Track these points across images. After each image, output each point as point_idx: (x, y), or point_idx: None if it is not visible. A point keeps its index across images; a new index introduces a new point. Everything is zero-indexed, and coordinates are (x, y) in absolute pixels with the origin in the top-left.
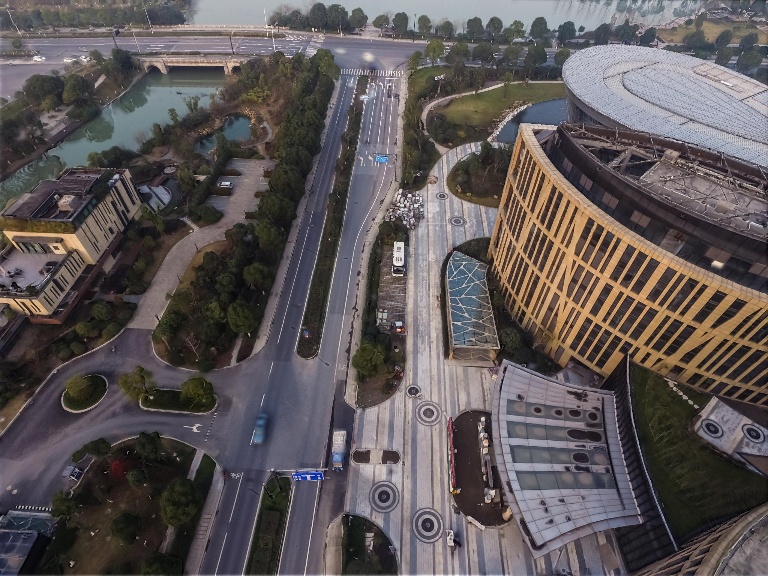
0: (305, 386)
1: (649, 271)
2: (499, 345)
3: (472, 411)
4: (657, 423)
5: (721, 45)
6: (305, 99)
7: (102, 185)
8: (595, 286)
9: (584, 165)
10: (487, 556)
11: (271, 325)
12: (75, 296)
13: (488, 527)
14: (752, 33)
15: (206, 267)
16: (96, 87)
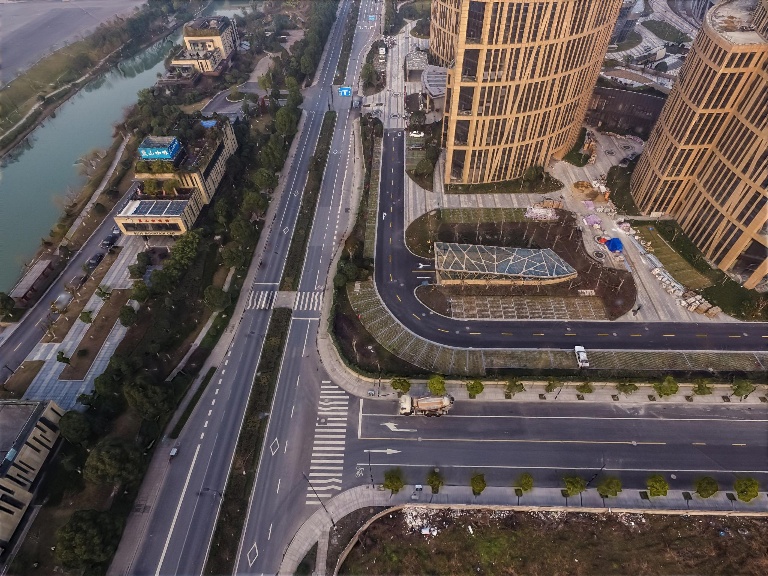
0: None
1: None
2: None
3: (416, 93)
4: None
5: None
6: None
7: (227, 19)
8: None
9: None
10: None
11: (319, 78)
12: (221, 67)
13: None
14: None
15: (283, 58)
16: None
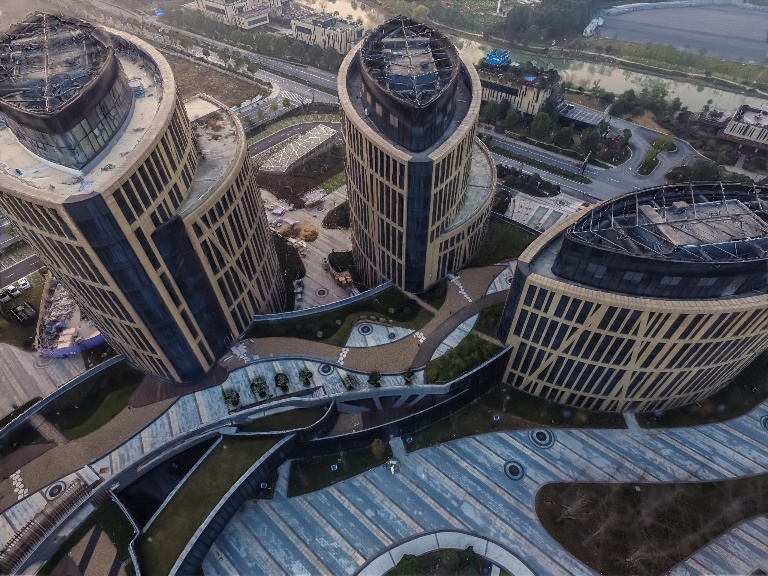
0: None
1: None
2: None
3: None
4: None
5: None
6: None
7: None
8: None
9: None
10: None
11: None
12: None
13: None
14: None
15: None
16: None
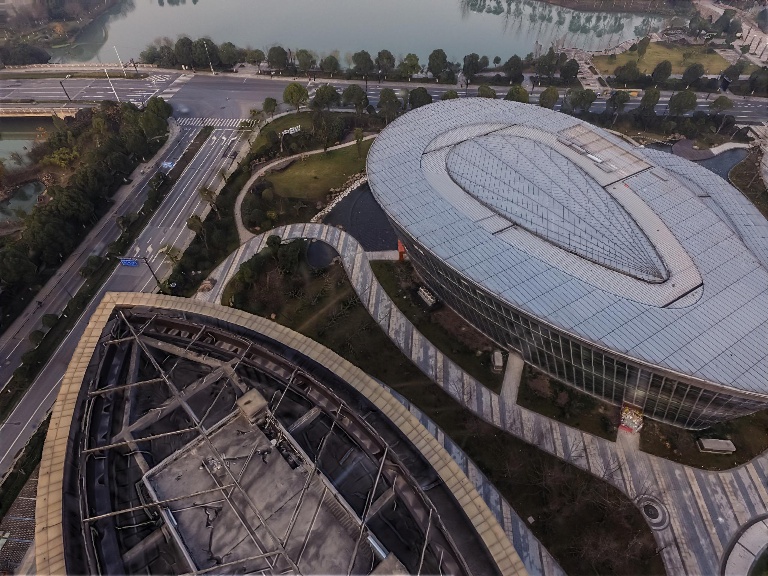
0: None
1: None
2: None
3: None
4: None
5: (659, 79)
6: None
7: None
8: None
9: None
10: None
11: None
12: None
13: None
14: (696, 64)
15: None
16: None
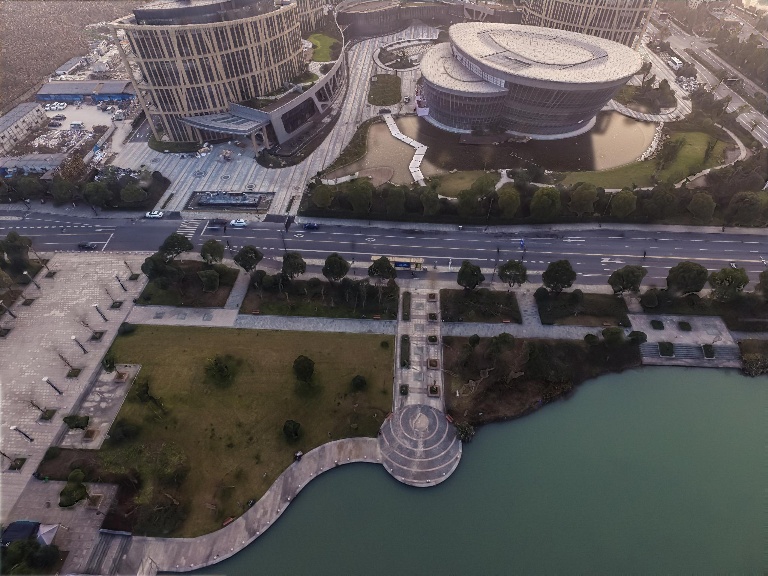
0: (679, 45)
1: None
2: None
3: None
4: None
5: None
6: None
7: None
8: None
9: None
10: None
11: (710, 54)
12: None
13: None
14: (294, 255)
15: None
16: None
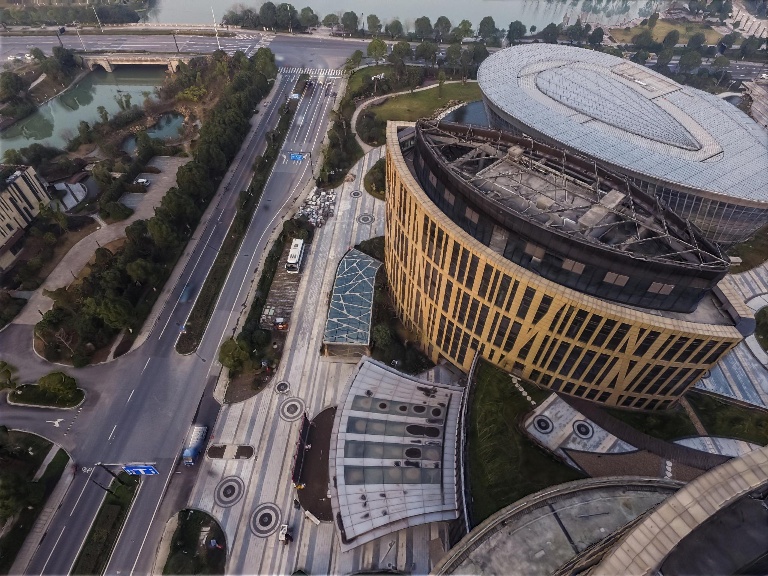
0: (177, 382)
1: (474, 267)
2: (369, 341)
3: (336, 407)
4: (484, 418)
5: (668, 45)
6: (230, 97)
7: None
8: (441, 282)
9: (430, 162)
10: (317, 550)
11: (156, 321)
12: None
13: (325, 522)
14: (699, 33)
15: (98, 263)
16: (35, 85)
